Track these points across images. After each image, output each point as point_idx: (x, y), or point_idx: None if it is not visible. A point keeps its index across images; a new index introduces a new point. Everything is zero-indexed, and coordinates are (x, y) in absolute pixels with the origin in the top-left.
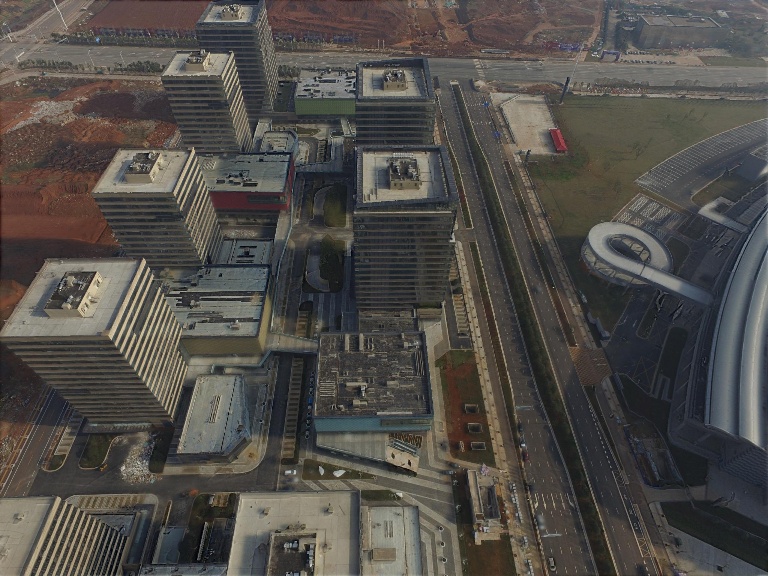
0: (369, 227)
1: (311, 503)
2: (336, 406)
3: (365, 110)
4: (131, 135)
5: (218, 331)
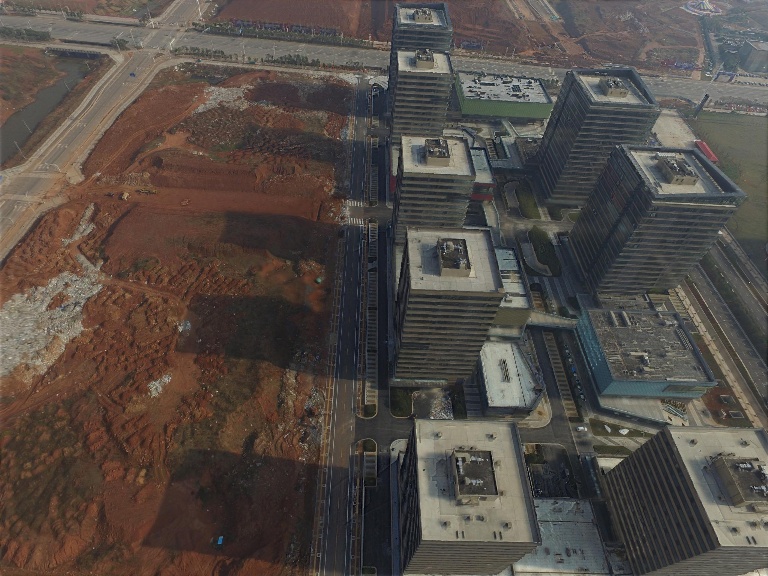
0: (658, 216)
1: (726, 437)
2: (628, 371)
3: (596, 113)
4: (309, 124)
5: None
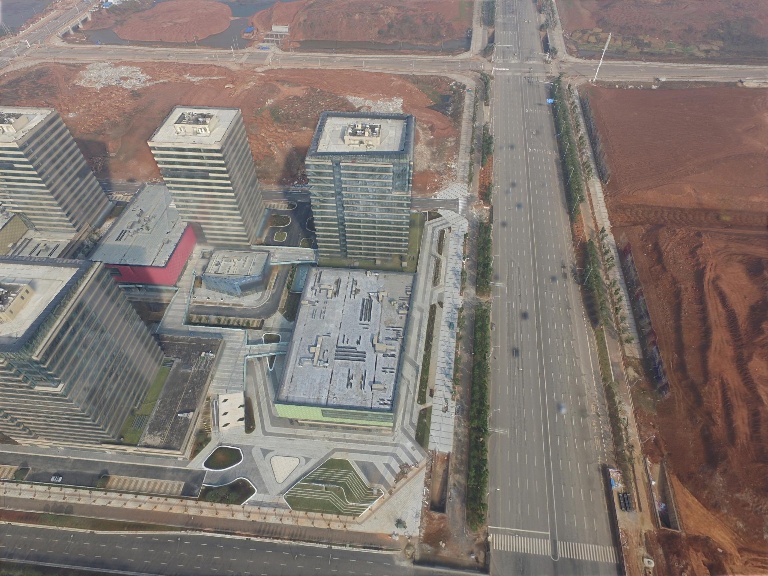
0: None
1: None
2: None
3: None
4: None
5: None
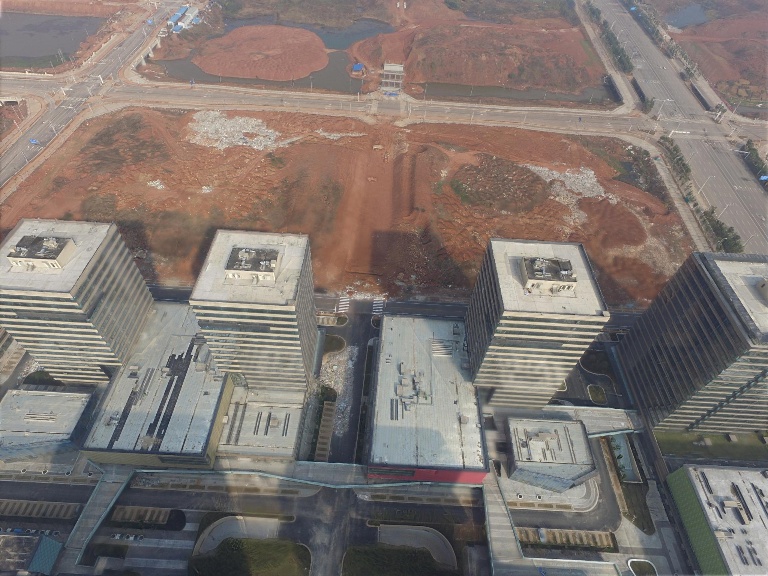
0: None
1: None
2: None
3: None
4: None
5: (114, 403)
